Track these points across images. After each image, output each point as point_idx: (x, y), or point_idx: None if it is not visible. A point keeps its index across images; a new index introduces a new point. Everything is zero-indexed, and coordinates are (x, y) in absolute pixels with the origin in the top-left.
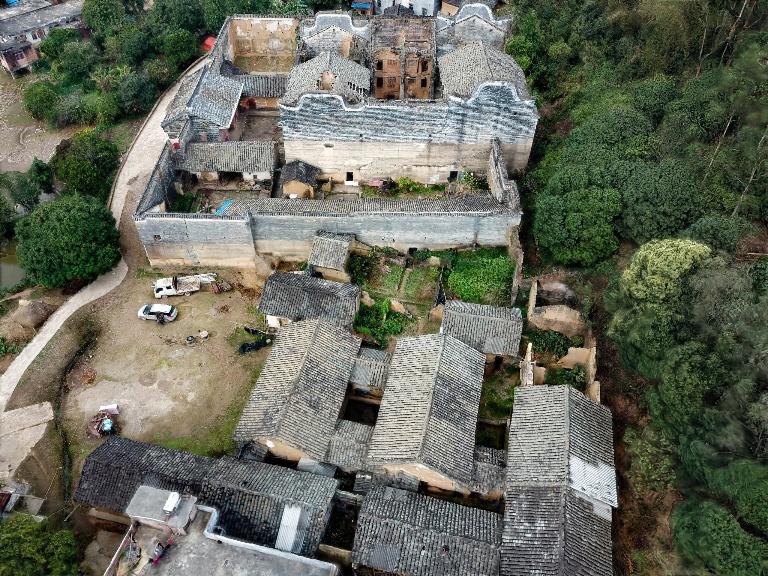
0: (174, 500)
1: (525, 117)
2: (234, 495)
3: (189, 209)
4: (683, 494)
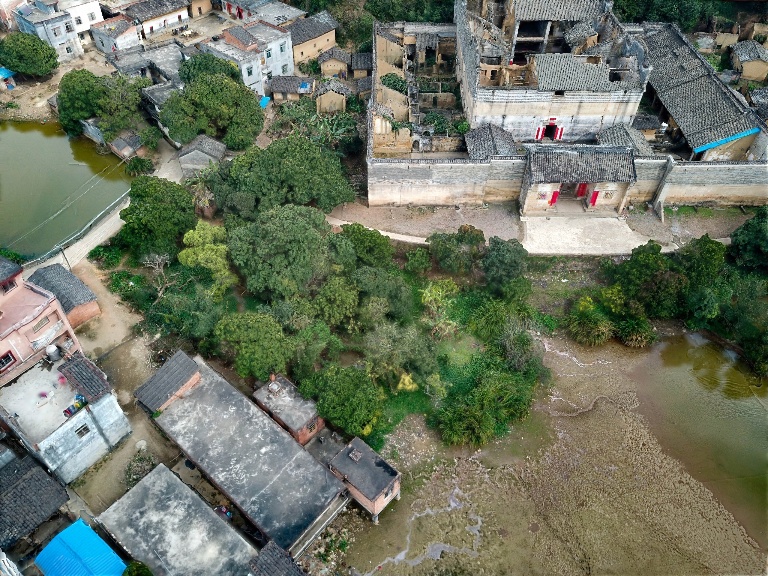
0: None
1: None
2: None
3: None
4: None
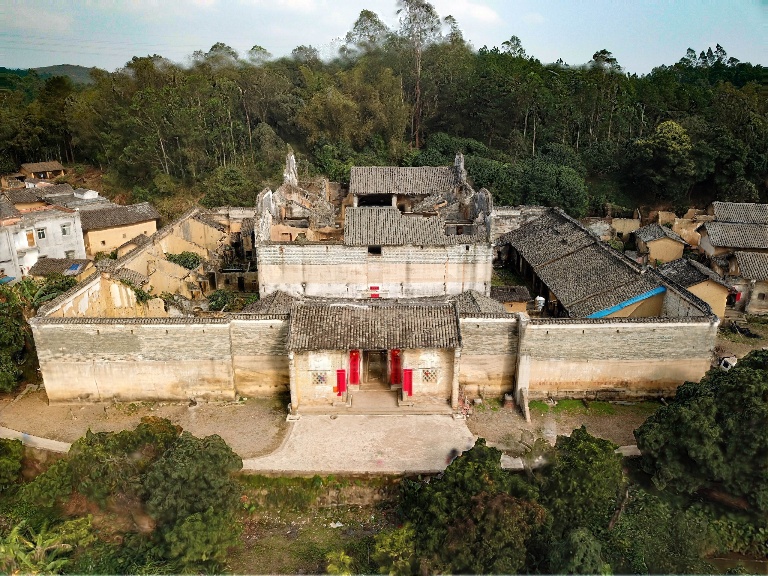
0: None
1: None
2: None
3: None
4: None
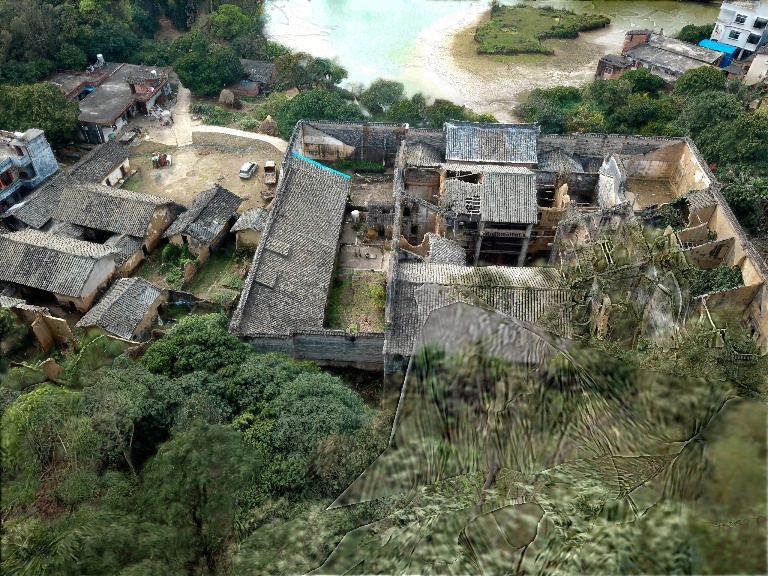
0: (19, 134)
1: None
2: None
3: (367, 172)
4: None
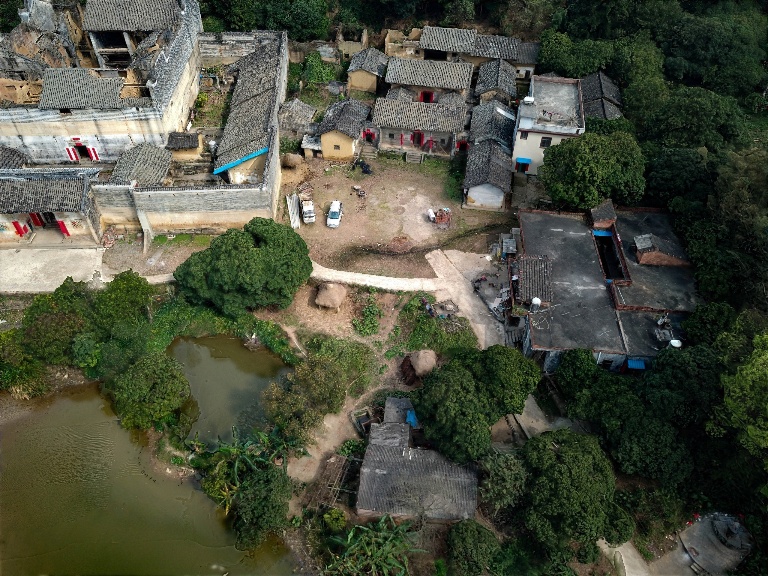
0: None
1: (196, 6)
2: (497, 125)
3: None
4: (482, 0)
